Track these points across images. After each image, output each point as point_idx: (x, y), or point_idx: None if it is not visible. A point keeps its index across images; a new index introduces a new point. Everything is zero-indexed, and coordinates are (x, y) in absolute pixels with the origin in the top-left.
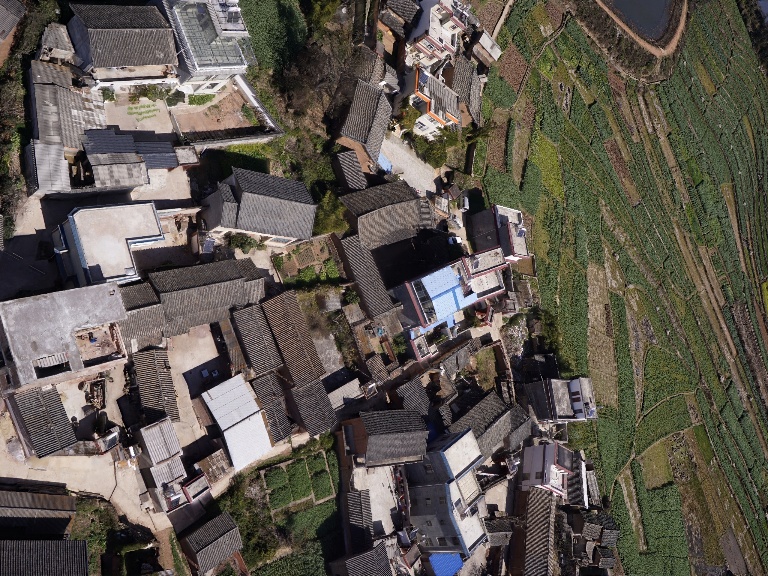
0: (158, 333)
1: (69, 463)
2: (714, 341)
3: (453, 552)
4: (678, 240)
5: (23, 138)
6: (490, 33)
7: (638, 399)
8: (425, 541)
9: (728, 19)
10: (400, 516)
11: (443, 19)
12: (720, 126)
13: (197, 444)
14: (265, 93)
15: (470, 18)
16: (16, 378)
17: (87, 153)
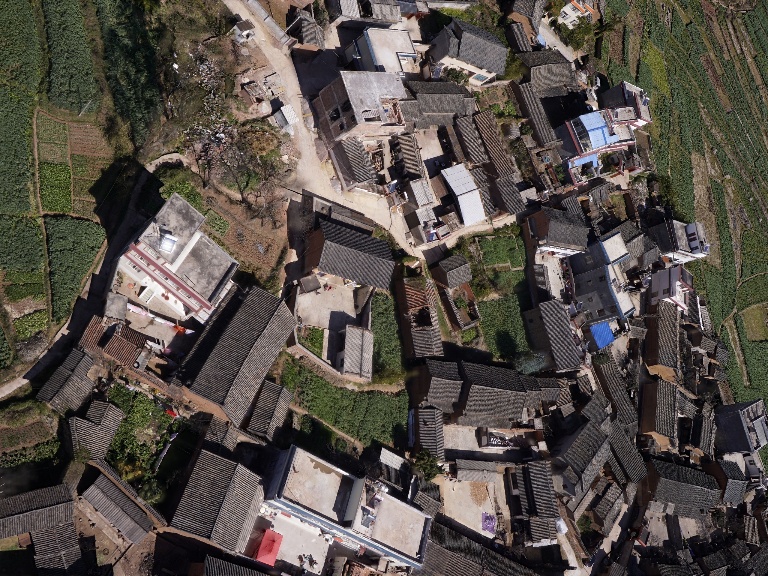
0: (412, 125)
1: (365, 202)
2: None
3: (610, 319)
4: (766, 146)
5: None
6: None
7: (737, 268)
8: (586, 316)
9: None
10: (567, 296)
11: None
12: None
13: (436, 210)
14: None
15: None
16: (351, 122)
17: None
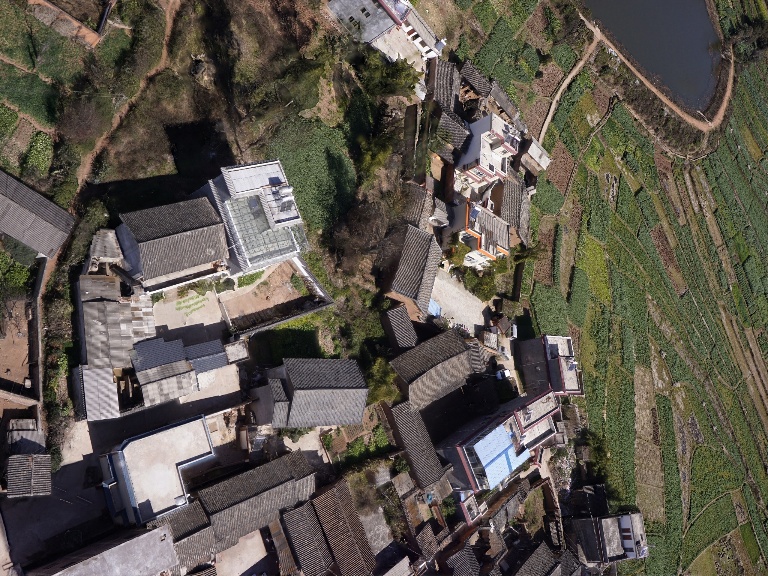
0: None
1: None
2: (761, 430)
3: None
4: (724, 325)
5: (71, 359)
6: (537, 134)
7: (685, 507)
8: None
9: None
10: None
11: (494, 143)
12: (766, 193)
13: None
14: (314, 255)
15: (518, 125)
16: None
17: (136, 371)
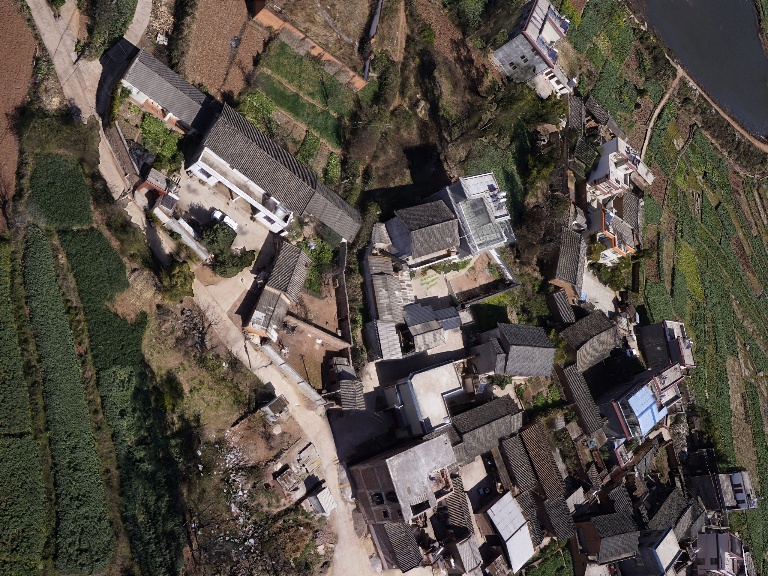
0: None
1: (406, 572)
2: None
3: None
4: None
5: (363, 316)
6: None
7: None
8: None
9: None
10: None
11: (618, 162)
12: None
13: (480, 550)
14: (499, 248)
15: None
16: (396, 515)
17: (408, 326)
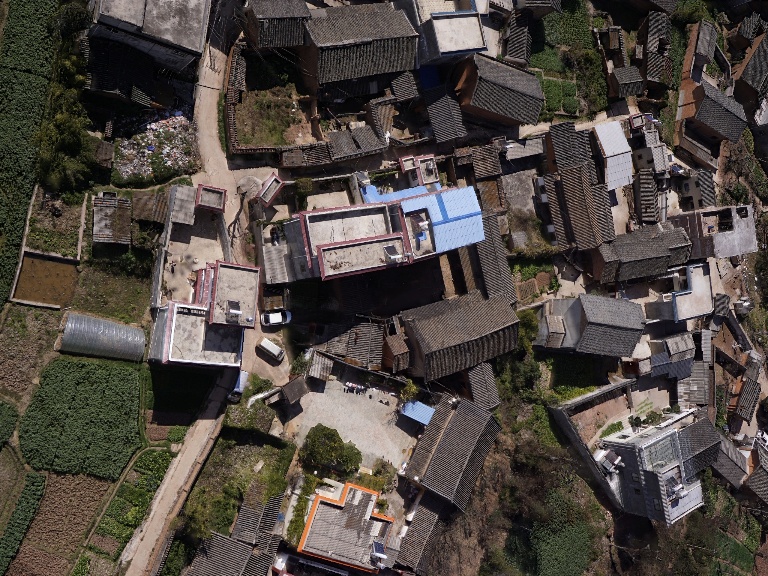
0: None
1: None
2: None
3: None
4: None
5: None
6: None
7: None
8: None
9: None
10: None
11: None
12: None
13: None
14: None
15: None
16: None
17: None
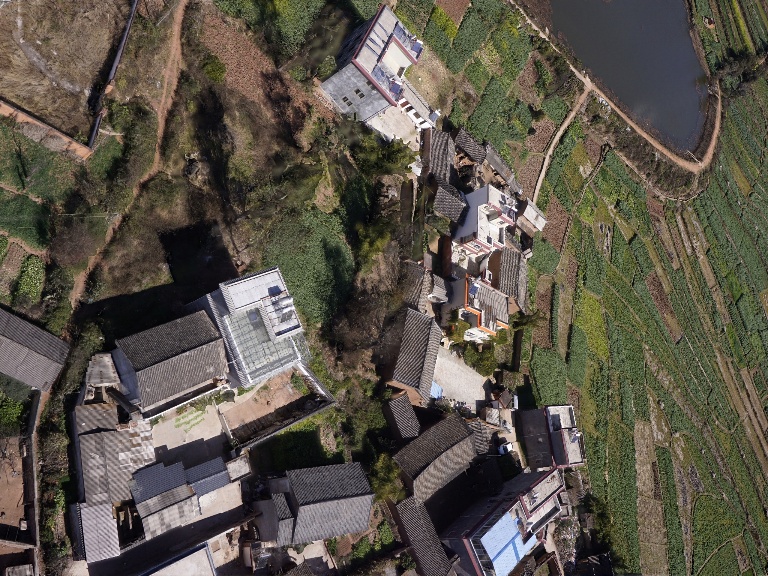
0: None
1: None
2: (759, 472)
3: None
4: (720, 368)
5: (68, 494)
6: (532, 192)
7: (688, 561)
8: None
9: (760, 107)
10: None
11: (490, 214)
12: (757, 228)
13: None
14: (314, 350)
15: (513, 186)
16: None
17: (136, 502)
